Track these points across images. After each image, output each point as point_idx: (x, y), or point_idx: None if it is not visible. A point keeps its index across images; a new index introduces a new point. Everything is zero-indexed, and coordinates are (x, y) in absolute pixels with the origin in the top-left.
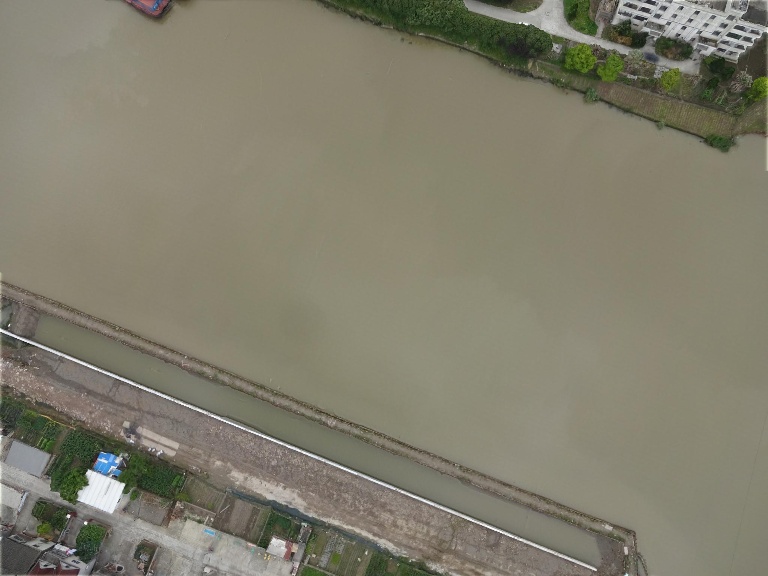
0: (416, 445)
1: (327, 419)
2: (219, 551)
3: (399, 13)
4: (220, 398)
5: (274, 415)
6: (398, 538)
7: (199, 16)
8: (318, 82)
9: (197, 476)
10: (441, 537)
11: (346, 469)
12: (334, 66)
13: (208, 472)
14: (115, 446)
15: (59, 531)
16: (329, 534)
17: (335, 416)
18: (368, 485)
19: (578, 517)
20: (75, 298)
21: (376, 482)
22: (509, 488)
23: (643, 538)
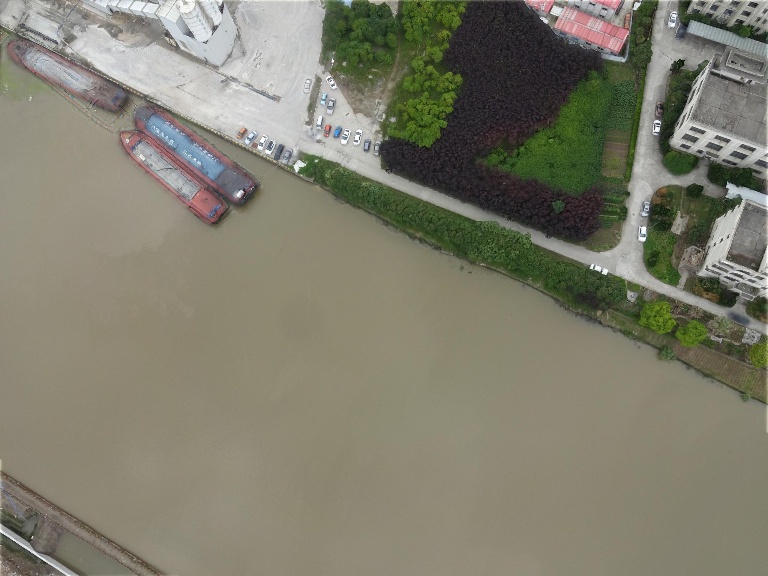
0: None
1: None
2: None
3: (460, 244)
4: None
5: None
6: None
7: (255, 225)
8: (368, 309)
9: None
10: None
11: None
12: (386, 292)
13: None
14: None
15: None
16: None
17: None
18: None
19: None
20: (98, 519)
21: None
22: None
23: None
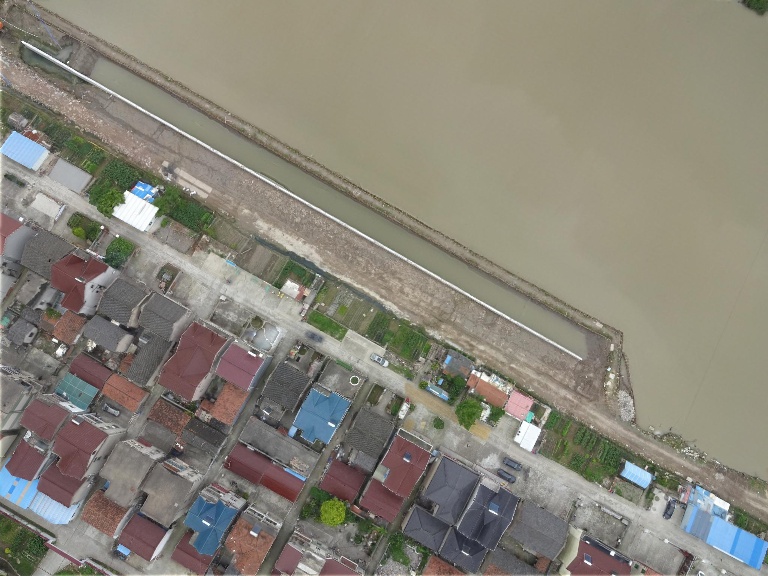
0: (432, 226)
1: (353, 189)
2: (236, 284)
3: None
4: (255, 158)
5: (303, 182)
6: (403, 303)
7: None
8: None
9: (225, 219)
10: (443, 309)
11: (364, 235)
12: None
13: (235, 217)
14: None
15: (91, 242)
16: (340, 289)
17: (361, 187)
18: (382, 253)
19: (572, 311)
20: None
21: (390, 251)
22: (512, 276)
23: (629, 340)
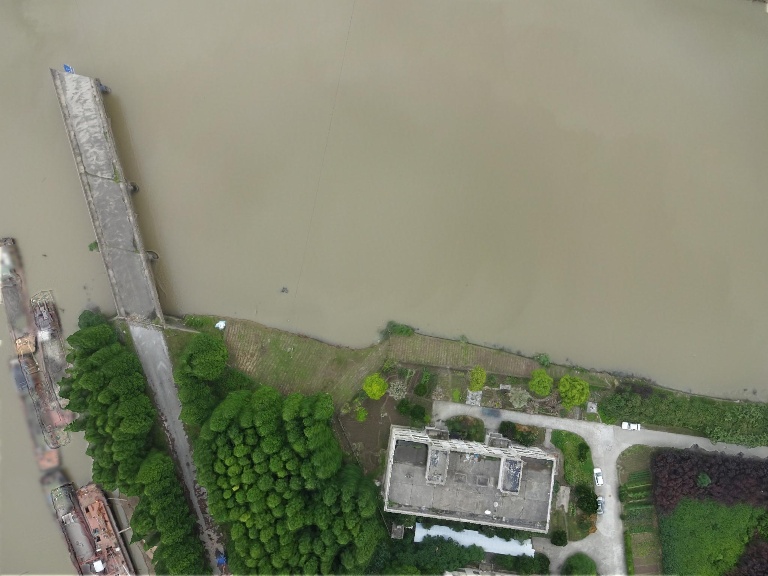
0: None
1: None
2: None
3: None
4: None
5: None
6: None
7: None
8: None
9: None
10: None
11: None
12: None
13: None
14: None
15: None
16: None
17: None
18: None
19: None
20: None
21: None
22: None
23: None
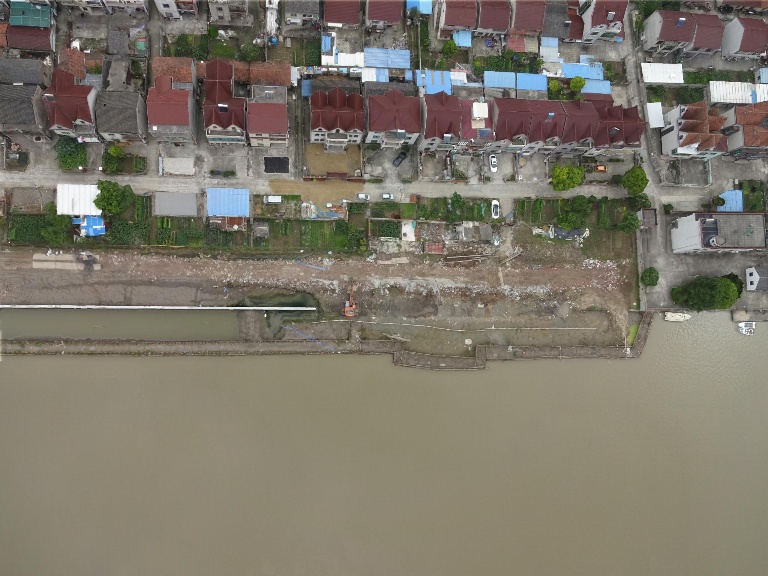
0: None
1: None
2: None
3: None
4: (16, 325)
5: None
6: None
7: None
8: None
9: None
10: None
11: None
12: None
13: None
14: (94, 244)
15: None
16: None
17: None
18: None
19: None
20: None
21: None
22: None
23: None
